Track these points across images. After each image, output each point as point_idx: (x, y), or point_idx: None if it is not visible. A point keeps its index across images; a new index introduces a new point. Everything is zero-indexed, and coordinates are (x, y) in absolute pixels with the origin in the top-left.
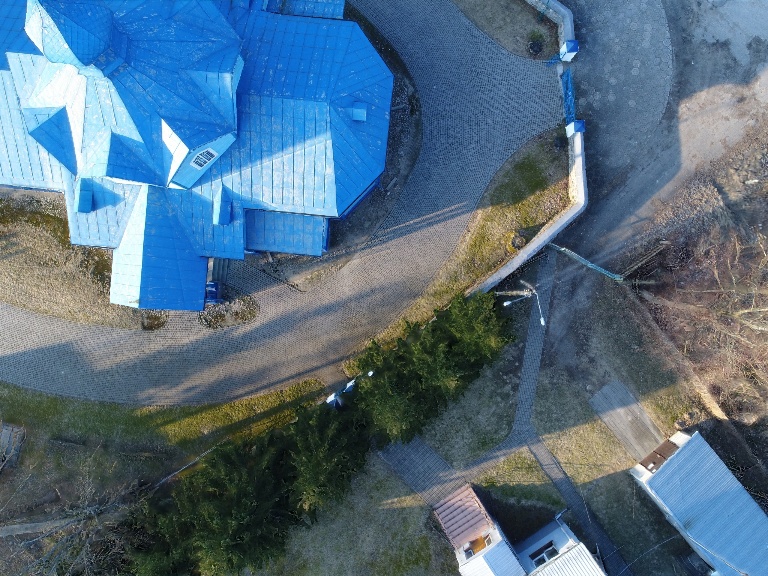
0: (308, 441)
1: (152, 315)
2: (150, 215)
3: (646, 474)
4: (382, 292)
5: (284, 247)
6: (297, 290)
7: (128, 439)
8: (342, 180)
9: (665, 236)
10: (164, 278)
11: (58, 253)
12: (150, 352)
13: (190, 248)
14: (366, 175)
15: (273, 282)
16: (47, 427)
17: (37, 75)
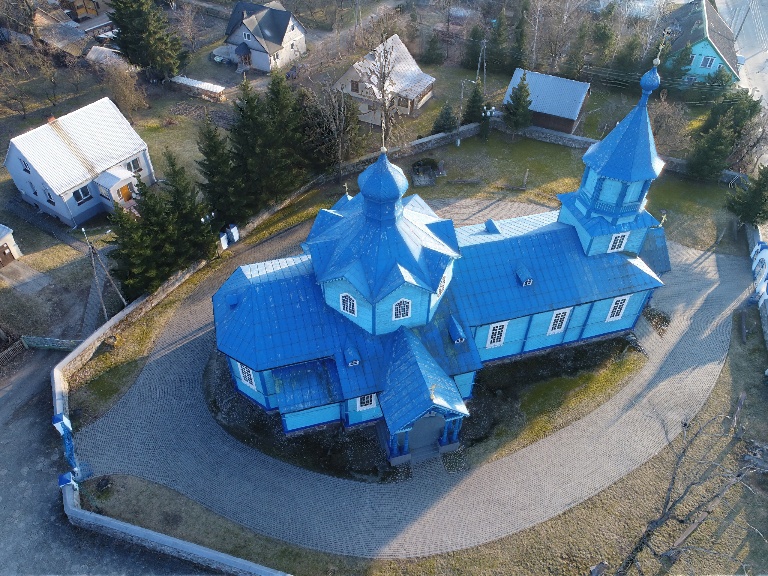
0: None
1: None
2: None
3: (11, 245)
4: None
5: None
6: None
7: None
8: None
9: None
10: None
11: None
12: None
13: None
14: None
15: None
16: None
17: None
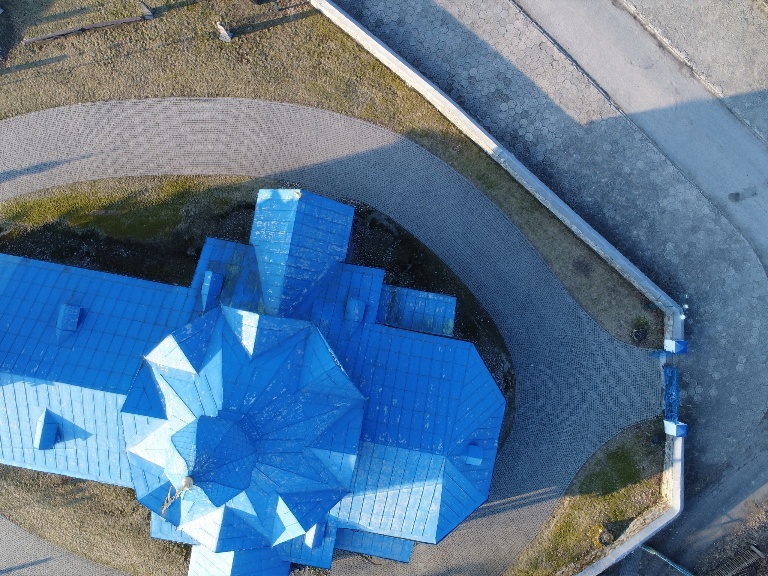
0: None
1: None
2: None
3: None
4: (458, 572)
5: (371, 551)
6: (370, 562)
7: None
8: (445, 514)
9: (756, 541)
10: None
11: (125, 503)
12: None
13: (275, 555)
14: (469, 505)
15: (346, 552)
16: None
17: (150, 430)
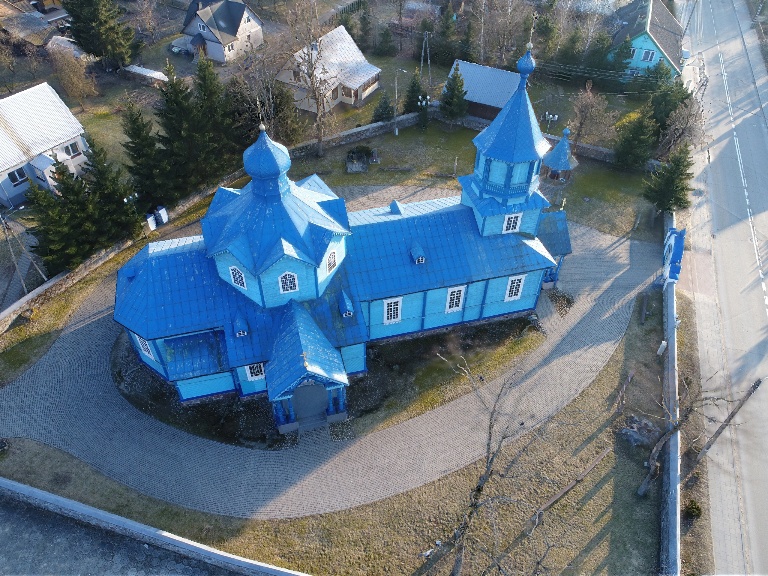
0: (150, 150)
1: None
2: None
3: None
4: None
5: None
6: None
7: None
8: None
9: None
10: None
11: None
12: None
13: None
14: None
15: None
16: (335, 176)
17: None
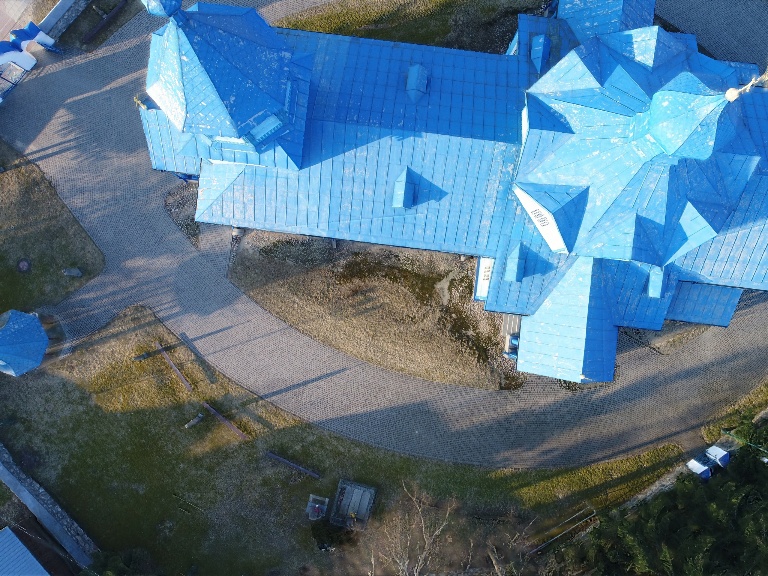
0: (759, 525)
1: (510, 375)
2: (592, 287)
3: None
4: (745, 357)
5: (691, 316)
6: (658, 353)
7: (481, 502)
8: None
9: None
10: (595, 350)
11: (416, 310)
12: (507, 413)
13: (610, 318)
14: None
15: (635, 344)
16: (399, 488)
17: (550, 151)
